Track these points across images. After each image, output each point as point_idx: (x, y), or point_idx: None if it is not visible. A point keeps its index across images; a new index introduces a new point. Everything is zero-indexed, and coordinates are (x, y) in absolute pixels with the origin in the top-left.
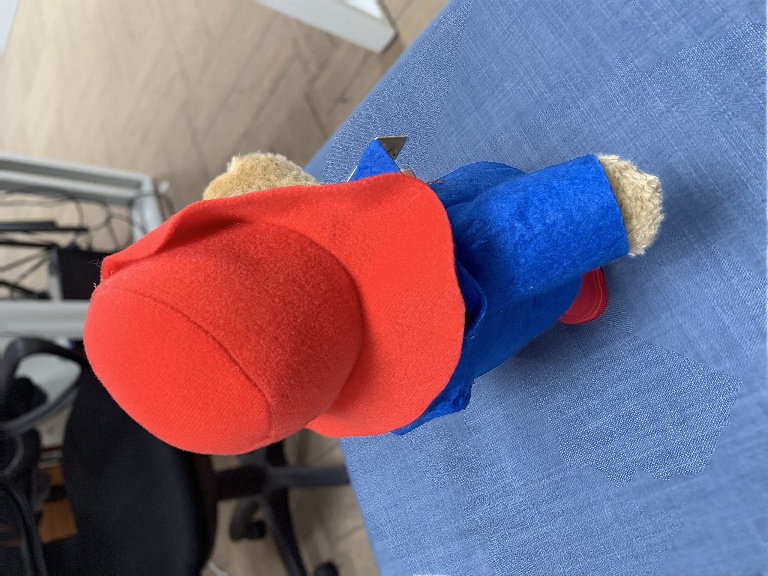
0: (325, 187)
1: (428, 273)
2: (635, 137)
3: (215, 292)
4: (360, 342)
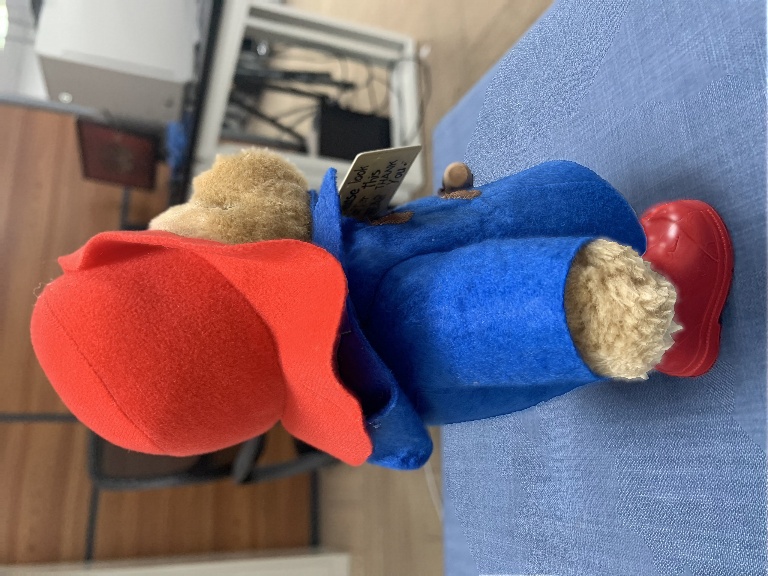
0: (200, 247)
1: (312, 356)
2: None
3: (104, 327)
4: (281, 387)
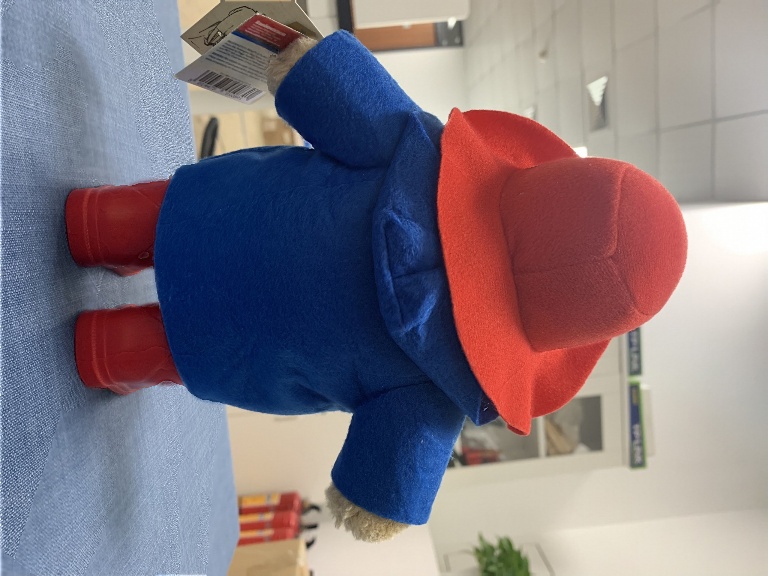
0: None
1: None
2: None
3: None
4: (527, 327)
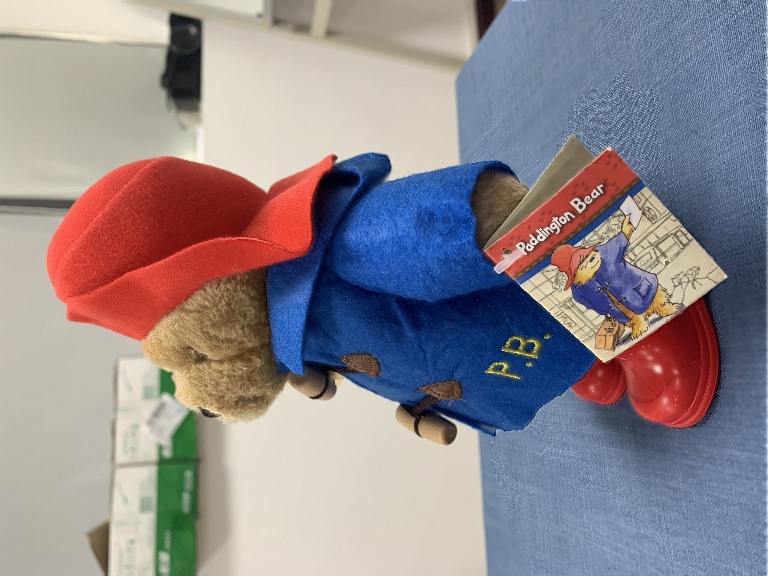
0: None
1: None
2: None
3: None
4: None
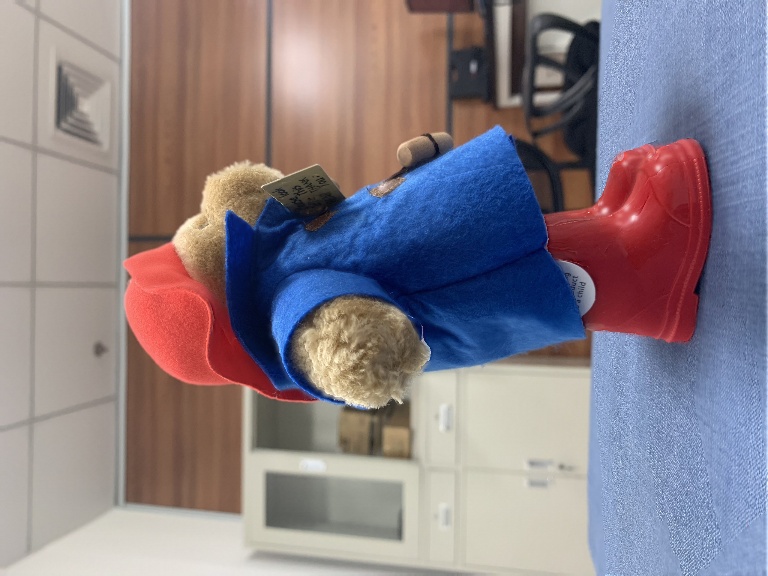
0: None
1: None
2: (760, 115)
3: (140, 318)
4: None
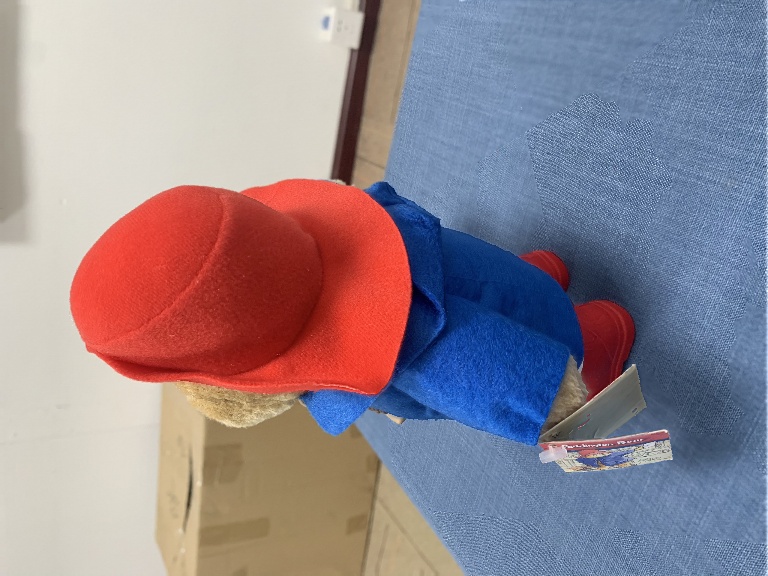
0: None
1: None
2: None
3: None
4: None
